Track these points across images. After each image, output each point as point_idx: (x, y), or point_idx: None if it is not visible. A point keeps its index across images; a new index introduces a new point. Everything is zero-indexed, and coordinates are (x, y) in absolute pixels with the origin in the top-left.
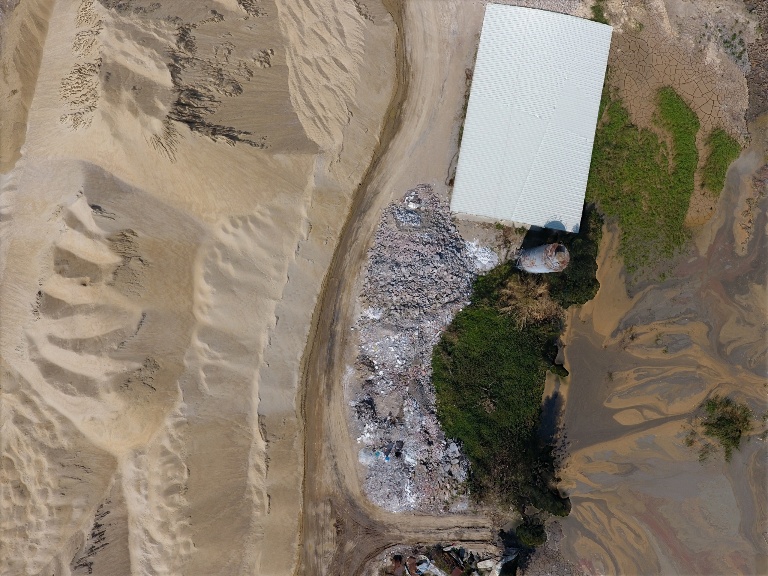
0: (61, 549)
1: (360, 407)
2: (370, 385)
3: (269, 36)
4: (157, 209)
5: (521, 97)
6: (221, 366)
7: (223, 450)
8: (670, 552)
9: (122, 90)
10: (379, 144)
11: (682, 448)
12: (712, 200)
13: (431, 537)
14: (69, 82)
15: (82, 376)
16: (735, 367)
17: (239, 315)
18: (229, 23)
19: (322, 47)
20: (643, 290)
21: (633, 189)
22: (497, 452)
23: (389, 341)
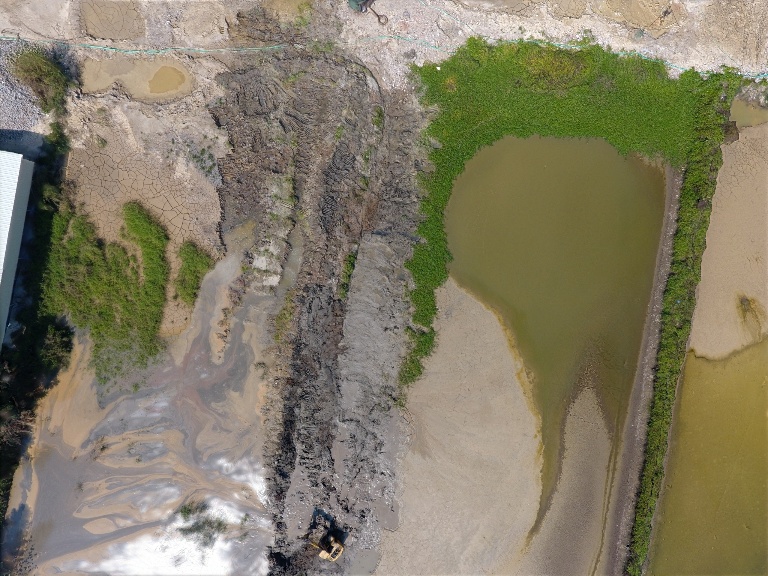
0: None
1: None
2: None
3: None
4: None
5: None
6: None
7: None
8: None
9: None
10: None
11: (157, 554)
12: (187, 310)
13: None
14: None
15: None
16: (212, 473)
17: None
18: None
19: None
20: (115, 401)
21: (101, 302)
22: None
23: None
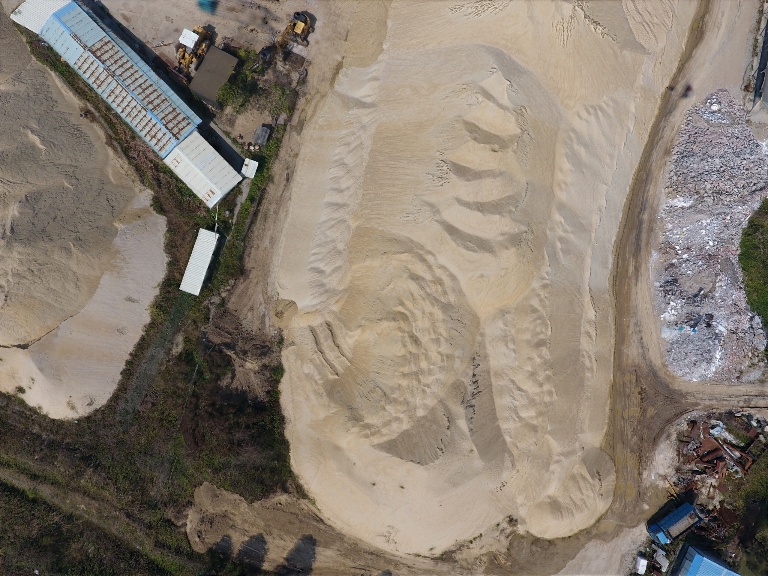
0: (444, 394)
1: (666, 287)
2: (674, 267)
3: None
4: (539, 91)
5: None
6: (569, 239)
7: (568, 315)
8: None
9: None
10: (684, 52)
11: None
12: None
13: (723, 404)
14: None
15: (476, 237)
16: None
17: (583, 195)
18: None
19: None
20: None
21: None
22: None
23: (701, 225)
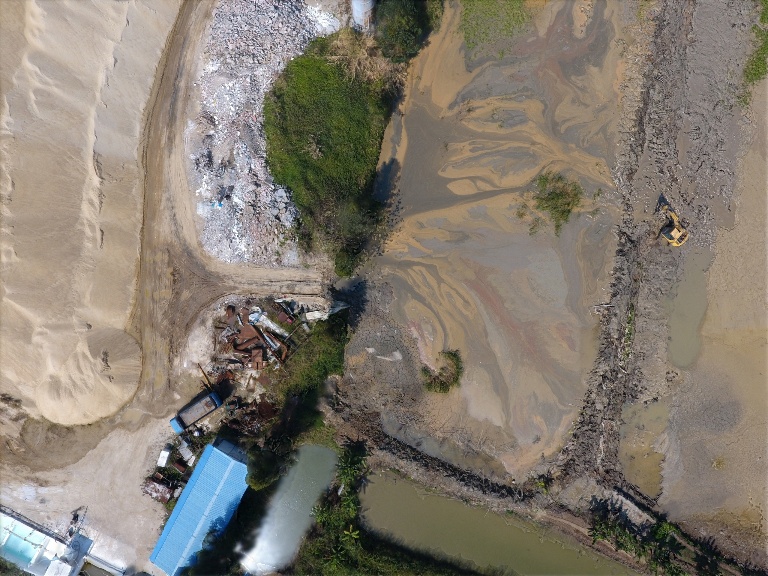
0: None
1: (199, 159)
2: (209, 138)
3: None
4: None
5: None
6: (54, 94)
7: (54, 176)
8: (497, 320)
9: None
10: None
11: (513, 220)
12: None
13: (264, 289)
14: None
15: None
16: (568, 145)
17: (74, 48)
18: None
19: None
20: (482, 66)
21: None
22: (323, 199)
23: (224, 89)
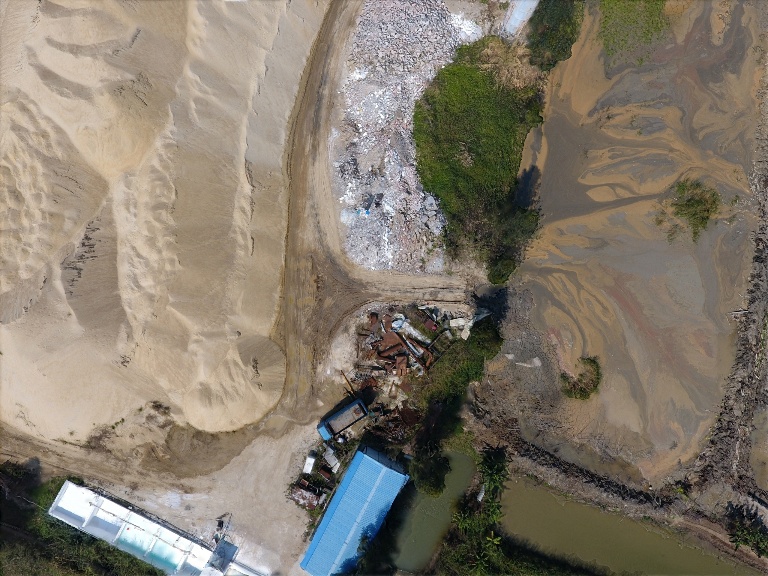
0: (52, 257)
1: (344, 166)
2: (354, 146)
3: None
4: None
5: None
6: (211, 102)
7: (210, 184)
8: (636, 326)
9: None
10: None
11: (652, 227)
12: None
13: (407, 296)
14: None
15: (78, 84)
16: (706, 152)
17: (230, 56)
18: None
19: None
20: (621, 73)
21: None
22: (473, 207)
23: (373, 97)
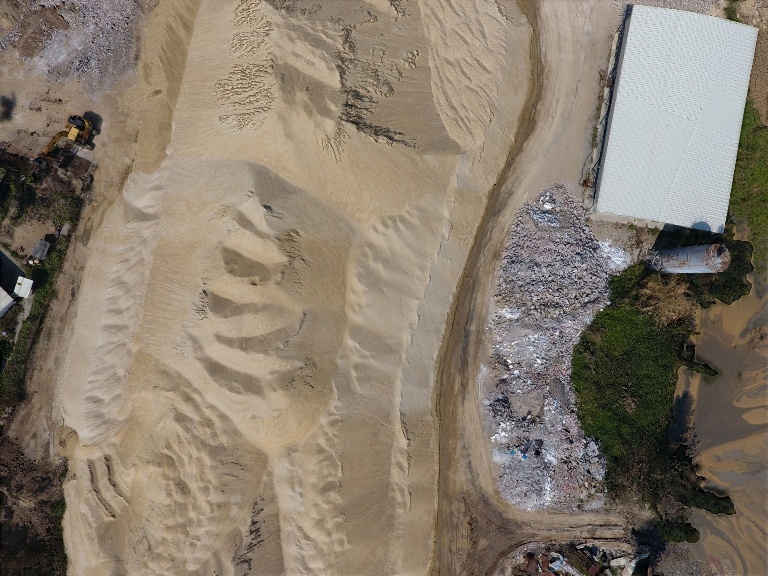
0: (219, 546)
1: (495, 406)
2: (505, 384)
3: (414, 37)
4: (317, 209)
5: (669, 98)
6: (369, 365)
7: (370, 448)
8: None
9: (296, 91)
10: (514, 144)
11: None
12: None
13: (564, 535)
14: (228, 83)
15: (245, 374)
16: None
17: (386, 314)
18: (382, 24)
19: (464, 48)
20: None
21: (763, 190)
22: (636, 451)
23: (528, 340)
